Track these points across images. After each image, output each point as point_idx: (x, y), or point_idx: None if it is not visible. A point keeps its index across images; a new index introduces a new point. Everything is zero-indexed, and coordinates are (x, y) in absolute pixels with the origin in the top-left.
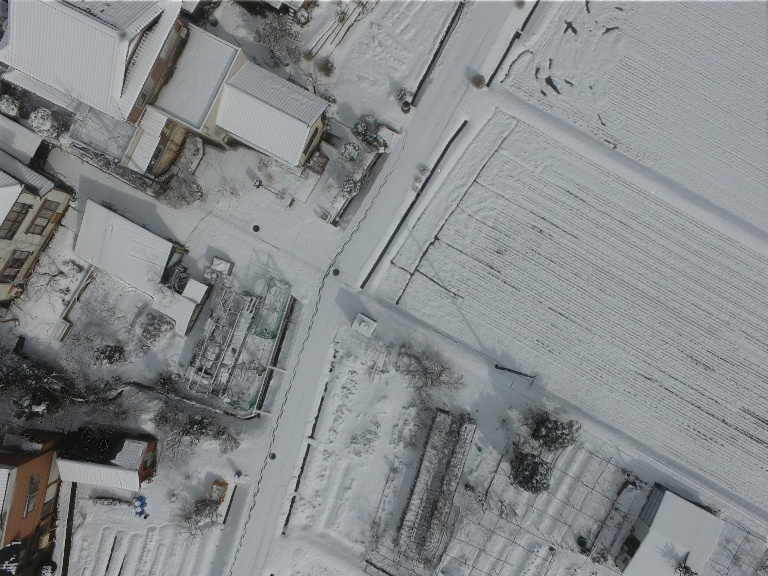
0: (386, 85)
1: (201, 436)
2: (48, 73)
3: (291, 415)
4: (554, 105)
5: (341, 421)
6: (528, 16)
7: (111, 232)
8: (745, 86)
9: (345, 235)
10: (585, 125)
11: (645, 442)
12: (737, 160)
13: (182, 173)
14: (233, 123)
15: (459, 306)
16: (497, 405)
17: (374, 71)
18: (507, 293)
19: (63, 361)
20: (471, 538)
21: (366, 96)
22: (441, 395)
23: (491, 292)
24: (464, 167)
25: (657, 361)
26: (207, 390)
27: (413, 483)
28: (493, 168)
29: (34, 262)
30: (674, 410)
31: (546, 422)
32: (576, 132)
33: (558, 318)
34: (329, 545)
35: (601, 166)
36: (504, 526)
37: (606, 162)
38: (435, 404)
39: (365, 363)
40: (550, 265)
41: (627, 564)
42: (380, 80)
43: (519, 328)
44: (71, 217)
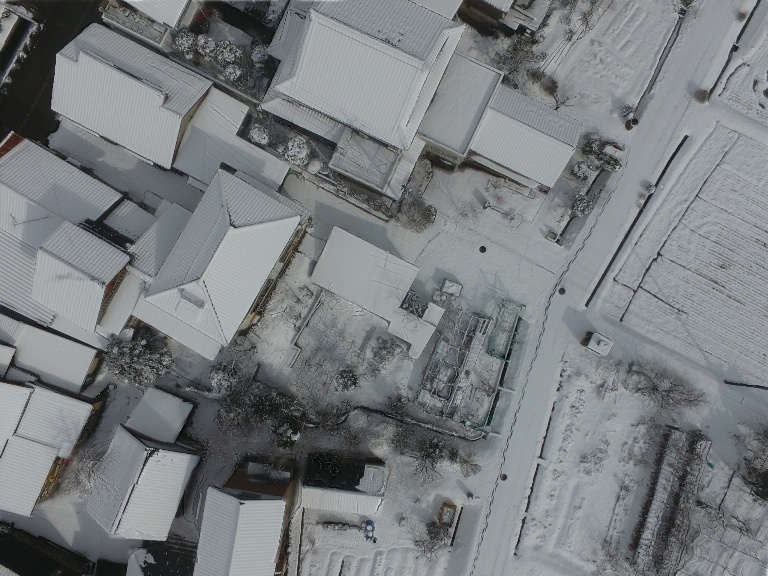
0: (608, 102)
1: (438, 459)
2: (332, 104)
3: (521, 436)
4: None
5: (570, 440)
6: (742, 29)
7: None
8: None
9: (570, 254)
10: None
11: None
12: None
13: (411, 196)
14: (489, 147)
15: (684, 322)
16: (727, 421)
17: (596, 88)
18: (732, 308)
19: (293, 387)
20: (711, 555)
21: (589, 114)
22: (673, 412)
23: (716, 307)
24: (686, 182)
25: None
26: (440, 413)
27: (646, 501)
28: (715, 183)
29: (271, 289)
30: None
31: None
32: None
33: None
34: (561, 565)
35: None
36: (745, 542)
37: None
38: (664, 421)
39: (595, 382)
40: None
41: None
42: (602, 97)
43: (745, 343)
44: (308, 243)
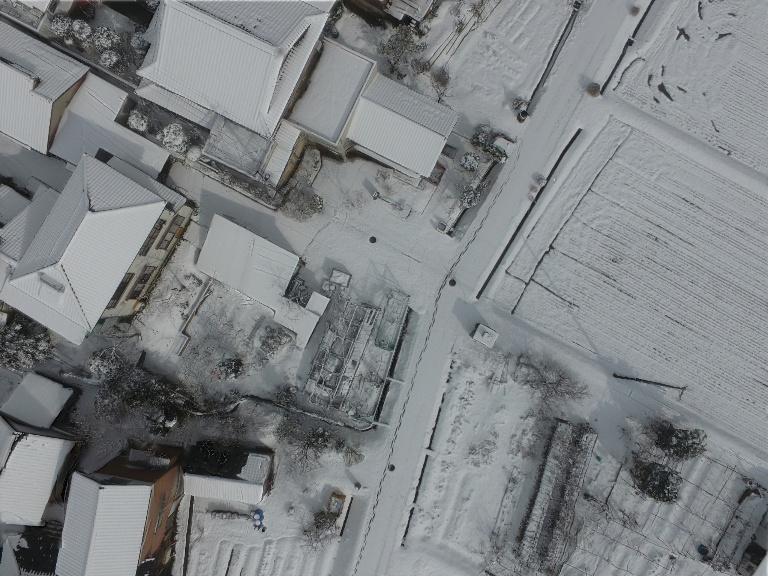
0: (501, 94)
1: (323, 449)
2: (194, 89)
3: (409, 426)
4: (667, 112)
5: (459, 432)
6: (639, 23)
7: None
8: None
9: (461, 245)
10: (699, 132)
11: (764, 449)
12: None
13: (300, 185)
14: (365, 136)
15: (575, 315)
16: (615, 414)
17: (489, 81)
18: (623, 301)
19: (181, 375)
20: (594, 548)
21: (481, 106)
22: (560, 405)
23: (607, 301)
24: (579, 176)
25: None
26: (327, 402)
27: (533, 493)
28: (608, 176)
29: (156, 277)
30: None
31: (675, 431)
32: (691, 139)
33: (675, 326)
34: (448, 556)
35: (717, 173)
36: (628, 536)
37: (722, 169)
38: (553, 414)
39: (483, 373)
40: (666, 273)
41: (753, 572)
42: (495, 89)
43: (636, 336)
44: (193, 231)
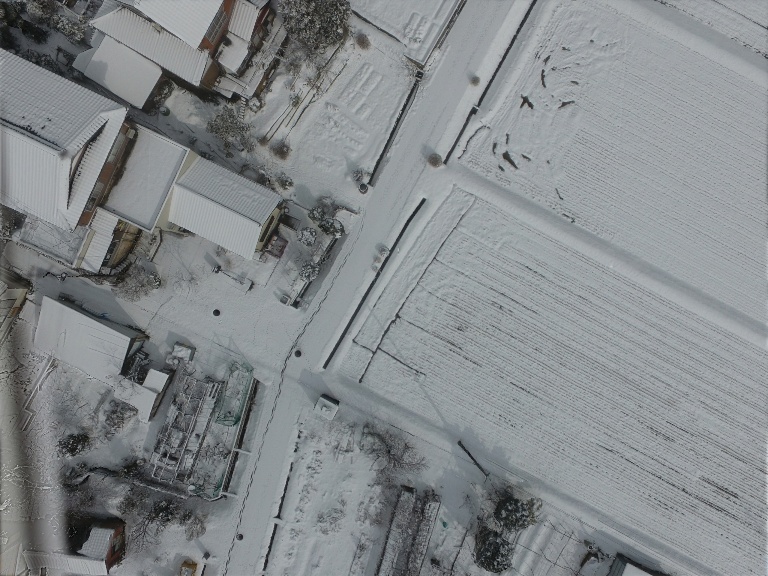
0: (343, 166)
1: (167, 522)
2: None
3: (257, 496)
4: (512, 180)
5: (307, 500)
6: (485, 90)
7: (64, 339)
8: (701, 158)
9: (306, 316)
10: (543, 200)
11: (607, 513)
12: (694, 232)
13: (140, 261)
14: (186, 220)
15: (421, 383)
16: (461, 481)
17: (331, 152)
18: (469, 369)
19: (27, 450)
20: None
21: (323, 177)
22: (405, 473)
23: (453, 369)
24: (423, 245)
25: (618, 433)
26: (172, 475)
27: (379, 560)
28: (452, 246)
29: None
30: (635, 481)
31: (506, 503)
32: (534, 208)
33: (520, 393)
34: None
35: (559, 241)
36: None
37: (564, 238)
38: (400, 481)
39: (329, 443)
40: (511, 341)
41: None
42: (337, 161)
43: (481, 404)
44: (29, 310)
